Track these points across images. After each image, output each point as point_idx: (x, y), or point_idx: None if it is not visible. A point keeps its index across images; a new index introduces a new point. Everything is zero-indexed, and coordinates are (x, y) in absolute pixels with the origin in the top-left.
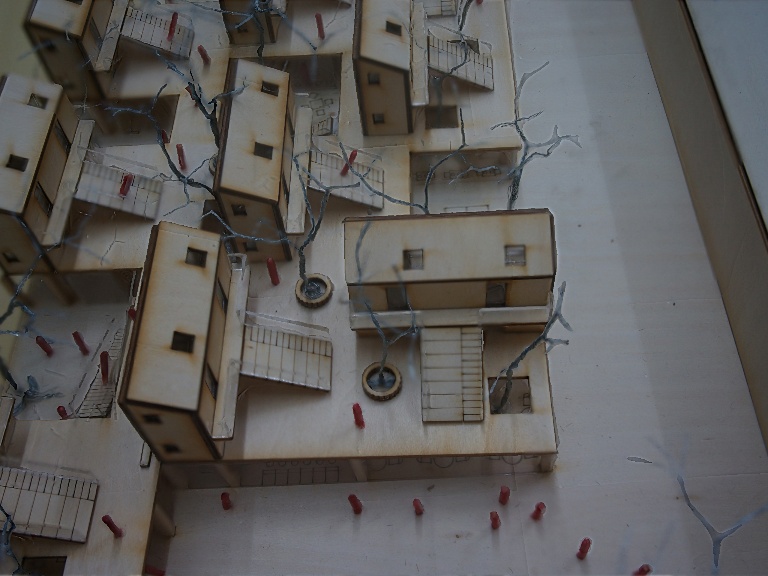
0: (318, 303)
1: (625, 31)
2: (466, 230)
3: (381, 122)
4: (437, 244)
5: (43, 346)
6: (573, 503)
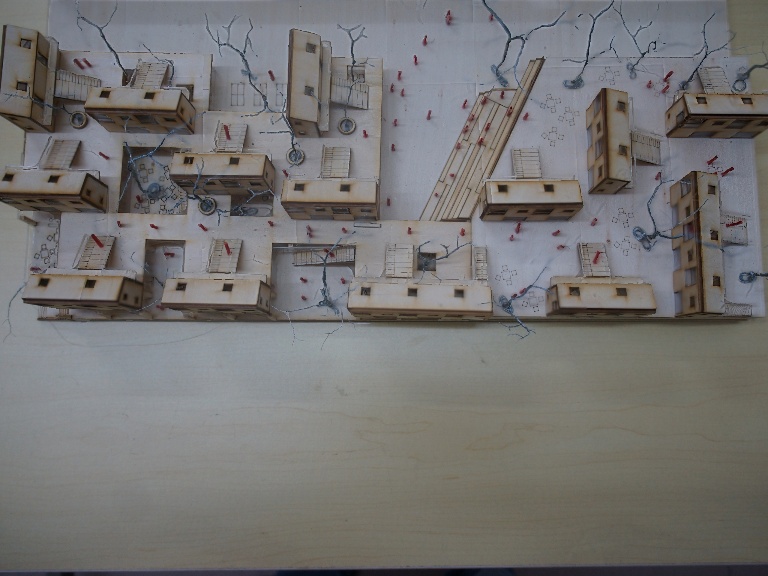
0: (303, 154)
1: None
2: (298, 66)
3: (191, 121)
4: (303, 80)
5: None
6: (394, 64)
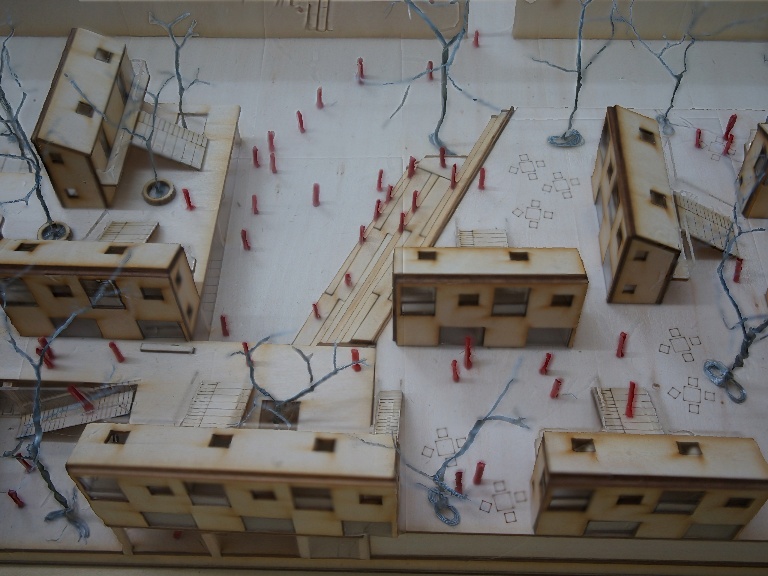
0: (70, 231)
1: None
2: (73, 73)
3: None
4: None
5: None
6: (266, 131)
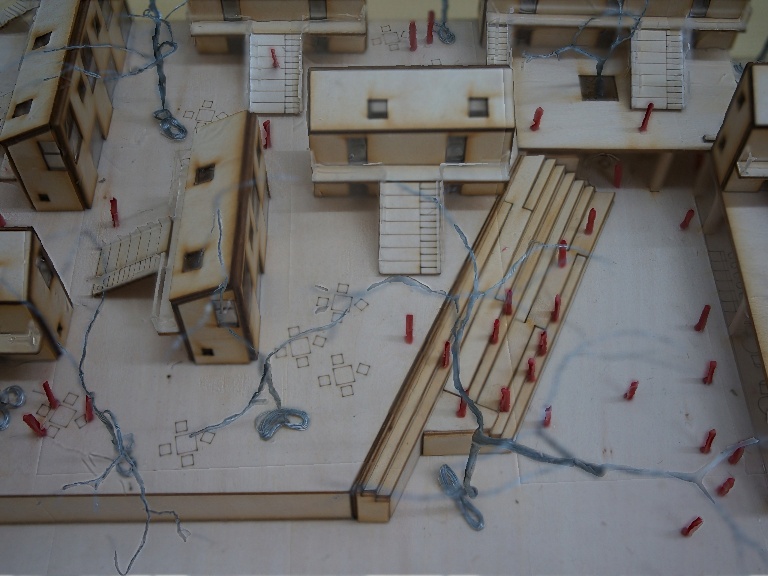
0: None
1: None
2: None
3: None
4: None
5: None
6: (743, 531)
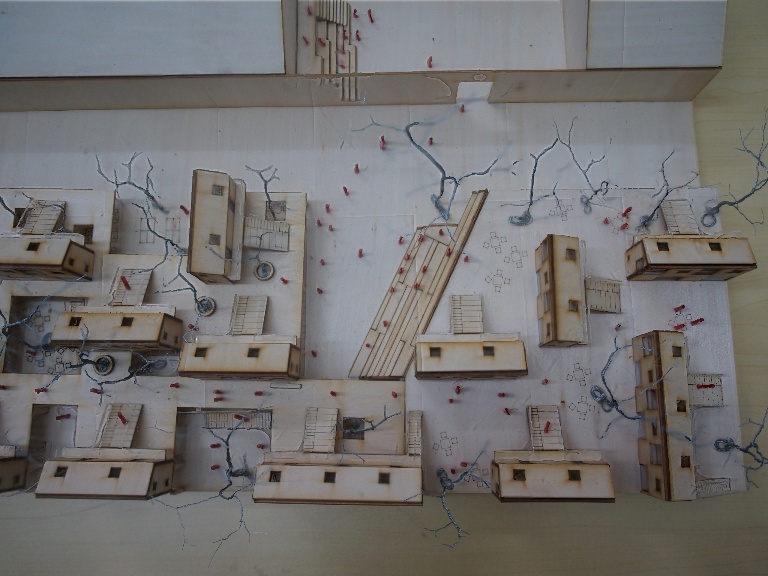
0: (214, 304)
1: (5, 121)
2: (202, 212)
3: (87, 268)
4: (208, 227)
5: (216, 468)
6: (323, 194)
